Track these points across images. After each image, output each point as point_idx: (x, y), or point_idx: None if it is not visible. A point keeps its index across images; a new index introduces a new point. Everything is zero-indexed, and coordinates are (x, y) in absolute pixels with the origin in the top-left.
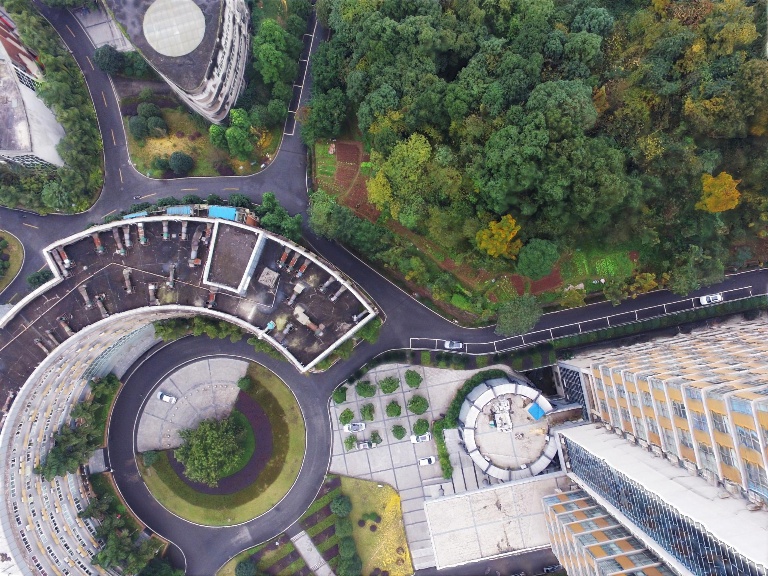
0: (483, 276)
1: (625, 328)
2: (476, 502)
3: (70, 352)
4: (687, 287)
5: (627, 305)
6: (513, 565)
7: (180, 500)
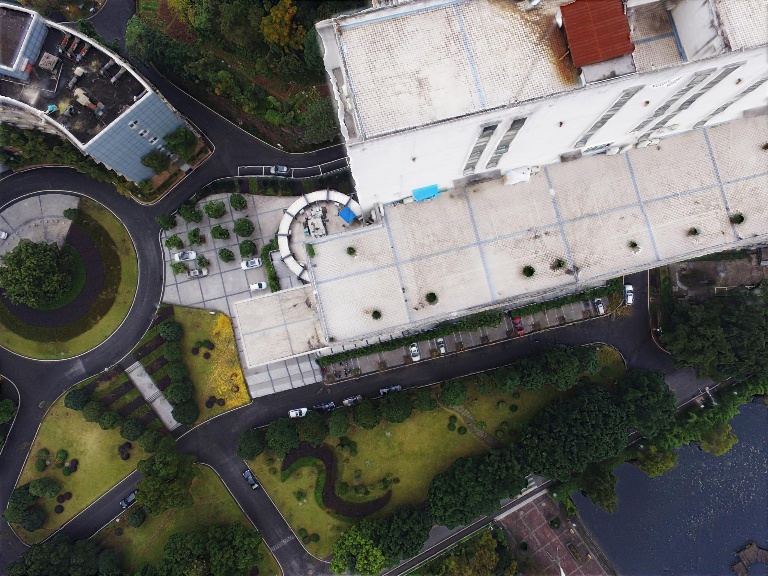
0: (294, 89)
1: None
2: (286, 301)
3: None
4: None
5: None
6: (350, 389)
7: (12, 335)
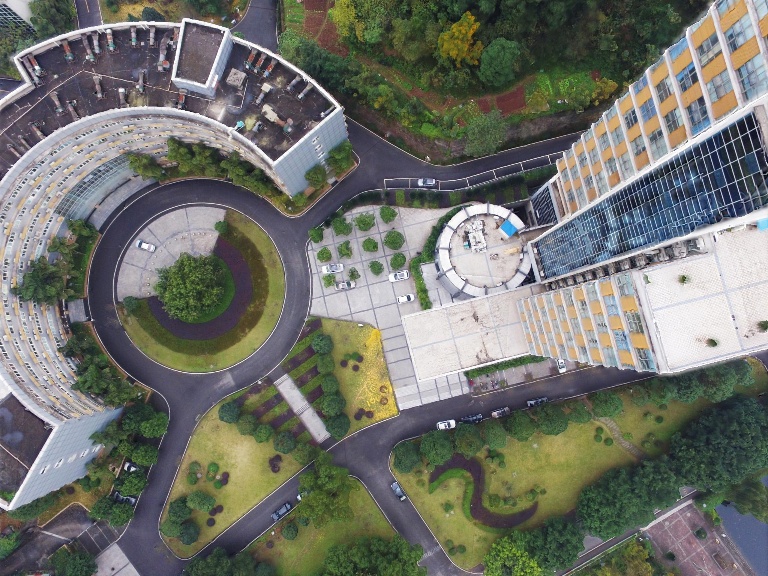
0: (451, 102)
1: None
2: (453, 315)
3: (44, 164)
4: None
5: None
6: (497, 401)
7: (162, 348)
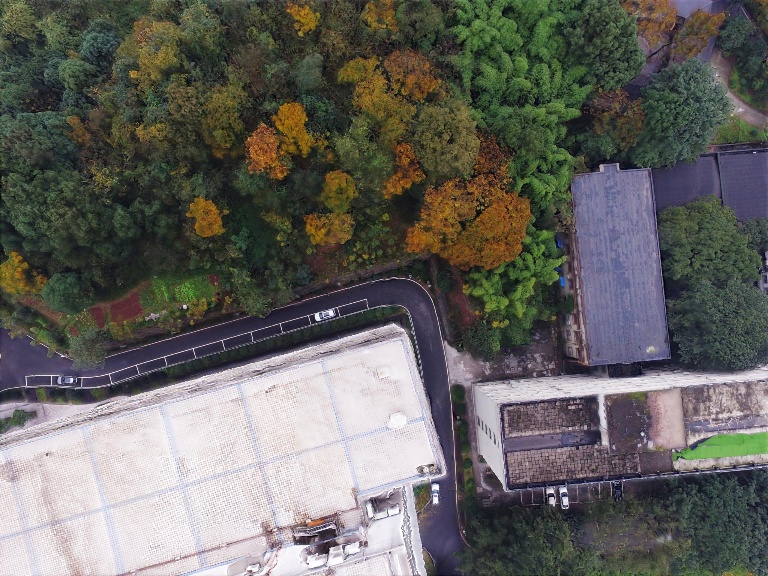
0: None
1: (239, 351)
2: None
3: None
4: (256, 309)
5: (242, 327)
6: None
7: None
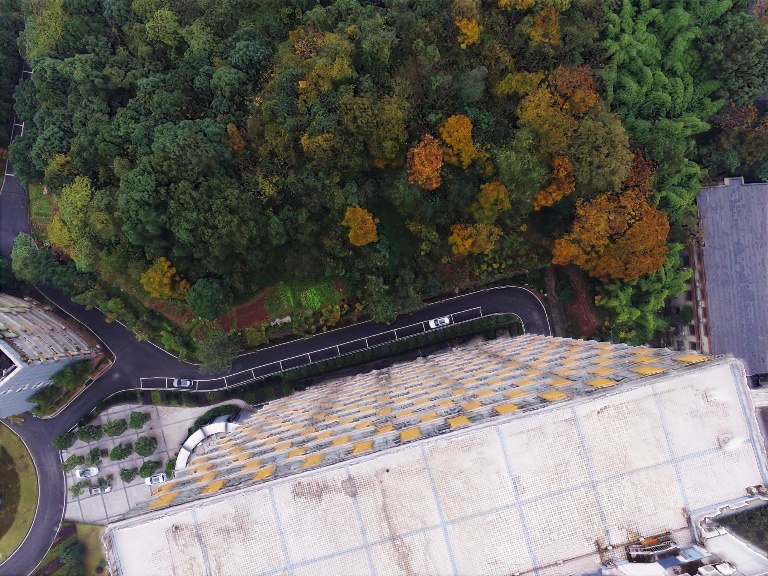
0: (190, 314)
1: (354, 356)
2: None
3: None
4: (385, 316)
5: (357, 332)
6: None
7: None
